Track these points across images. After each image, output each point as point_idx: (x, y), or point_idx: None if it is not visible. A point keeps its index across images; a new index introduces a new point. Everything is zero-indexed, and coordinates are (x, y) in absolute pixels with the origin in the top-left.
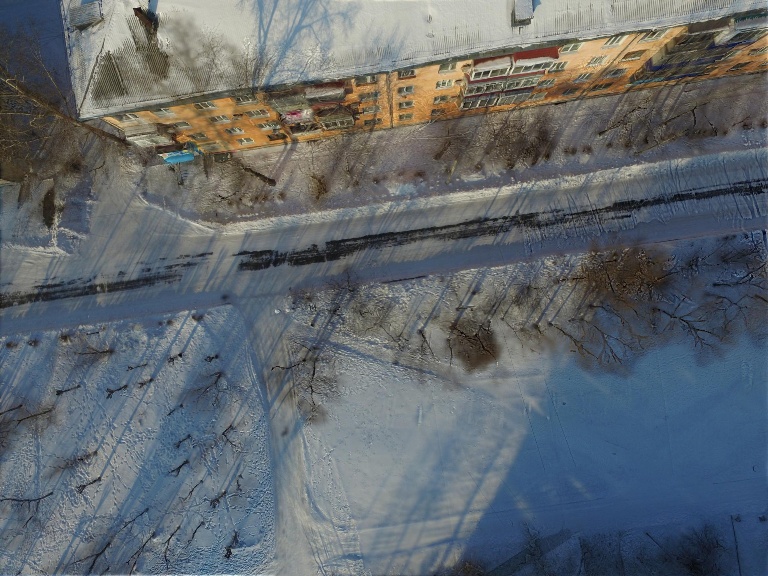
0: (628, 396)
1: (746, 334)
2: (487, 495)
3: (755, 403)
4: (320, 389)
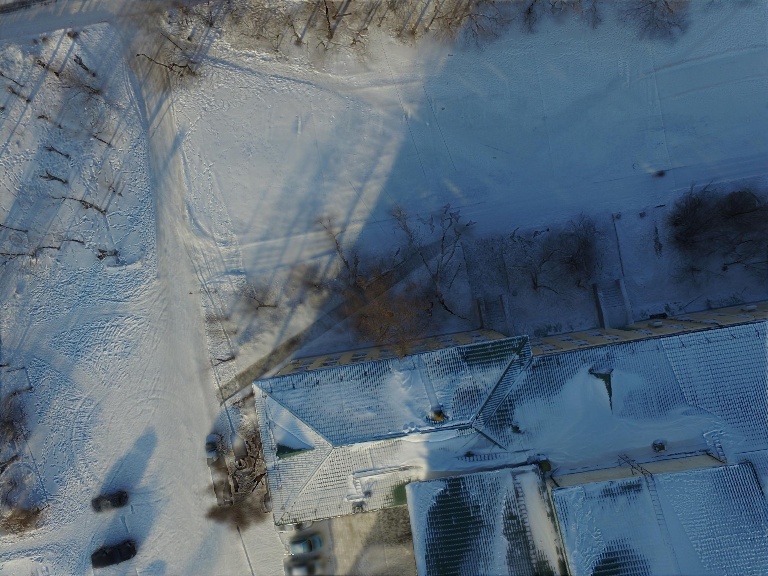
0: (506, 98)
1: (622, 32)
2: (369, 204)
3: (633, 101)
4: (198, 103)
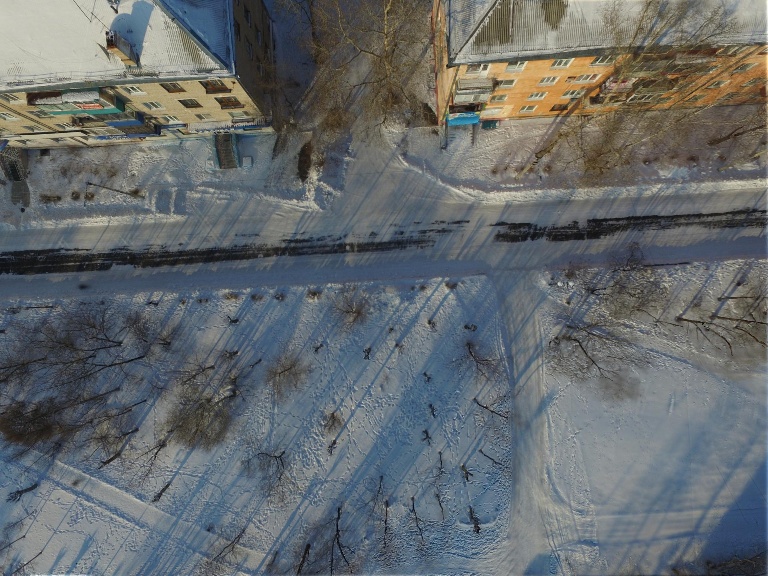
0: None
1: None
2: (733, 491)
3: None
4: (570, 369)
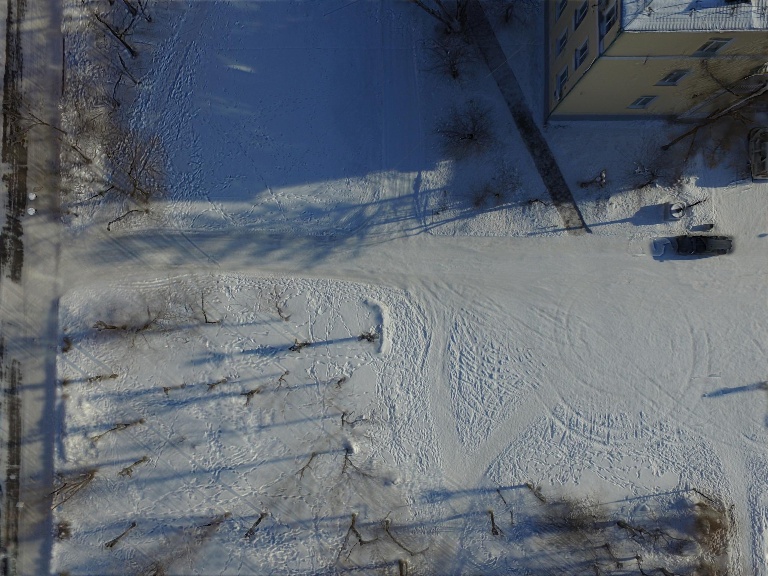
0: None
1: None
2: None
3: None
4: (187, 195)
